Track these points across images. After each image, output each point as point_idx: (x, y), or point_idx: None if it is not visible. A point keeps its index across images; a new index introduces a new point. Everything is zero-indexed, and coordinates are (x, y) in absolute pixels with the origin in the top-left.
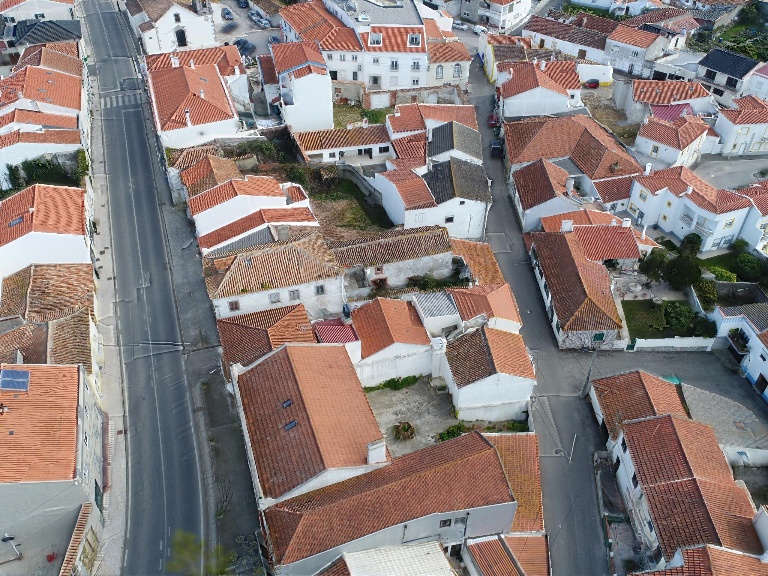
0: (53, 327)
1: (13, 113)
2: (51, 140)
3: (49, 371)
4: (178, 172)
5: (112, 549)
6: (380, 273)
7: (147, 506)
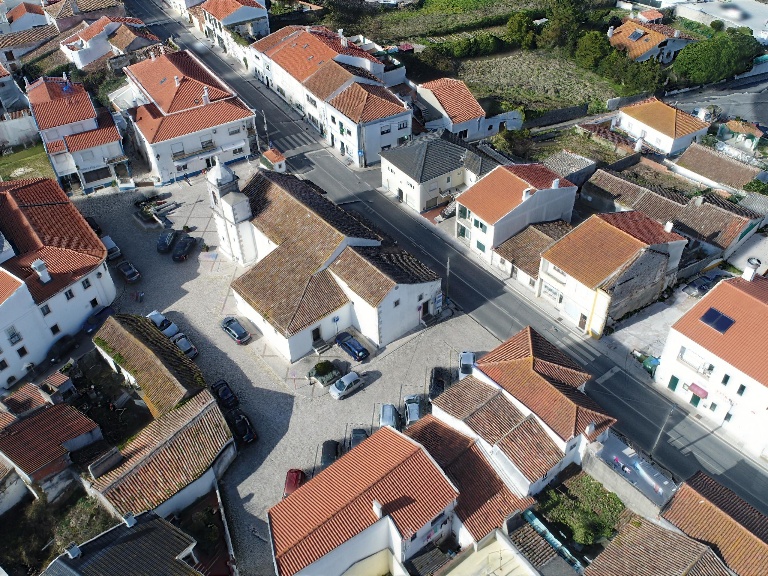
0: None
1: None
2: (272, 38)
3: None
4: None
5: None
6: None
7: None
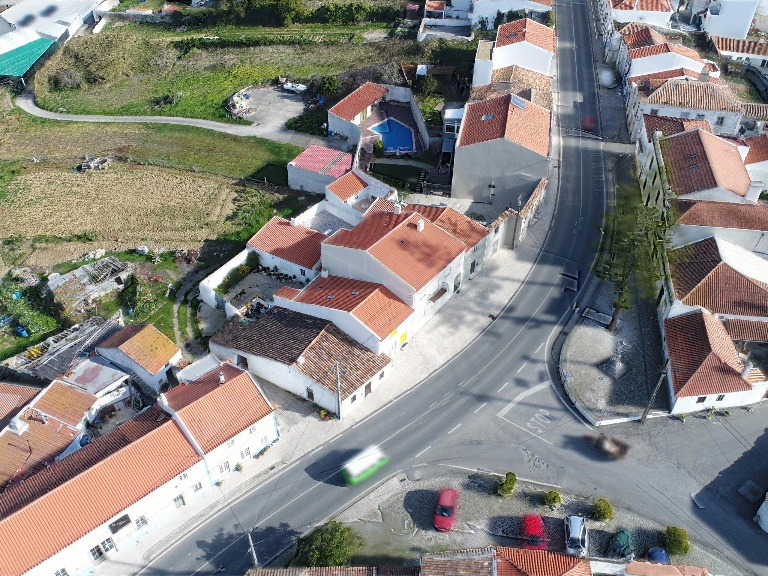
0: (534, 92)
1: None
2: None
3: (535, 107)
4: (621, 36)
5: (545, 216)
6: (766, 130)
7: (569, 204)
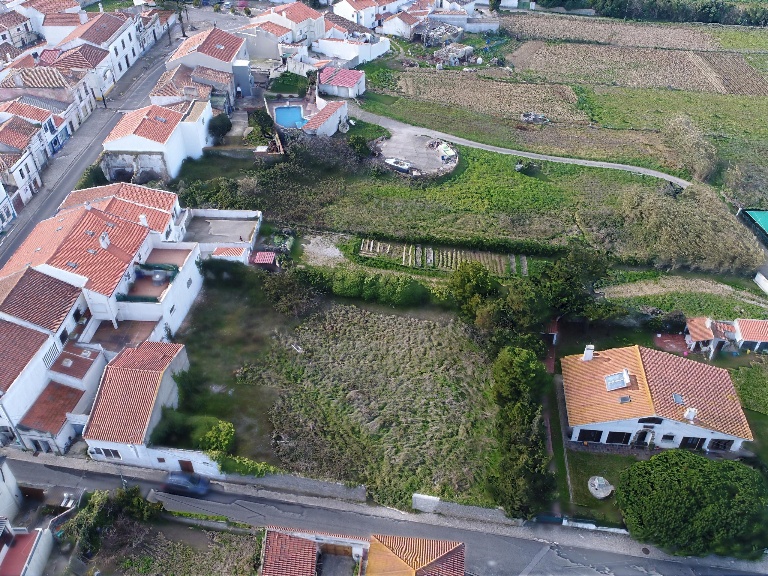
0: None
1: (108, 211)
2: (94, 193)
3: None
4: None
5: None
6: None
7: None
